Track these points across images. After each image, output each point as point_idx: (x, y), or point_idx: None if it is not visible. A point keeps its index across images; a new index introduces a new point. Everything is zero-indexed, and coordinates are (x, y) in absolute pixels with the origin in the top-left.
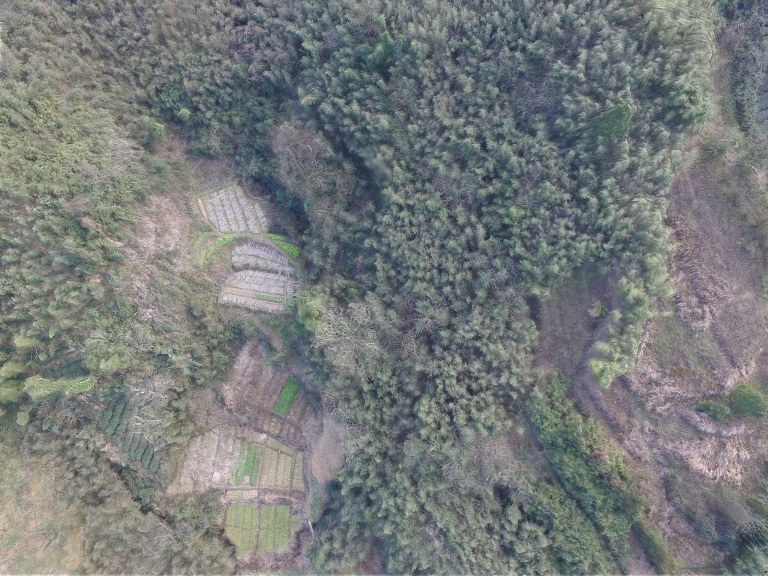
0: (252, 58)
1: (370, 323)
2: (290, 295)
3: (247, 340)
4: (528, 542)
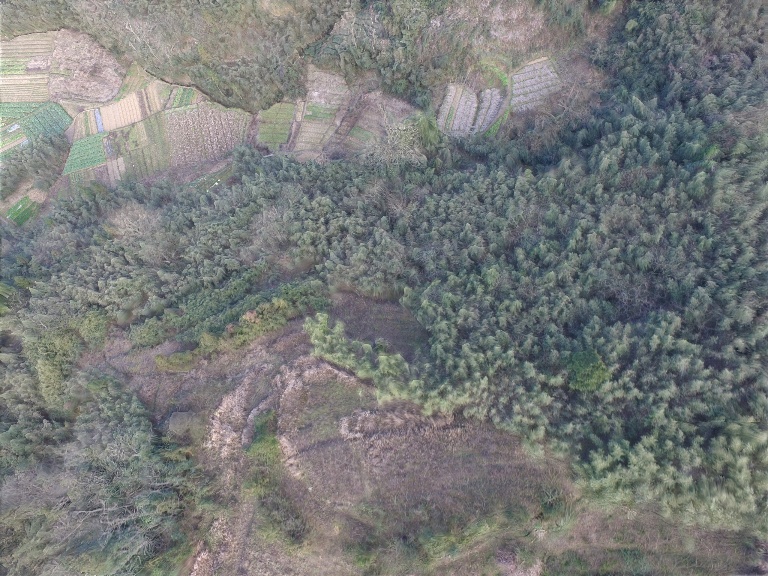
0: (699, 65)
1: (400, 160)
2: (451, 135)
3: (415, 106)
4: (210, 270)
